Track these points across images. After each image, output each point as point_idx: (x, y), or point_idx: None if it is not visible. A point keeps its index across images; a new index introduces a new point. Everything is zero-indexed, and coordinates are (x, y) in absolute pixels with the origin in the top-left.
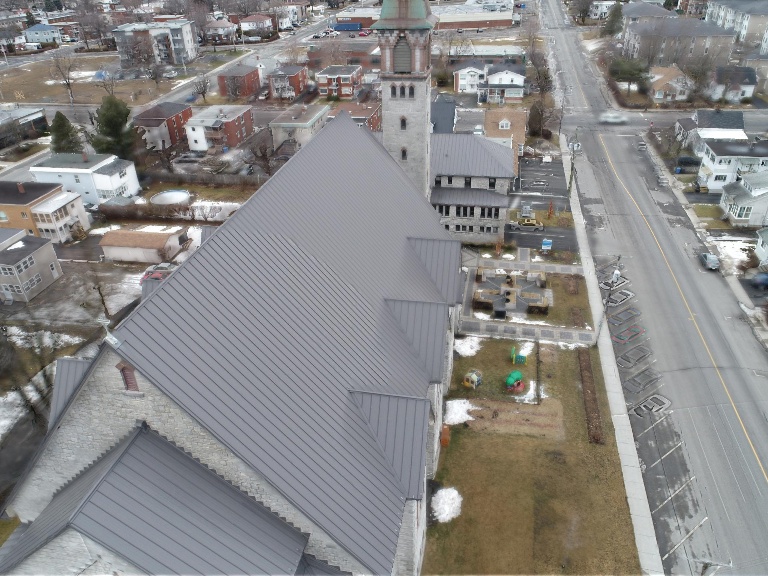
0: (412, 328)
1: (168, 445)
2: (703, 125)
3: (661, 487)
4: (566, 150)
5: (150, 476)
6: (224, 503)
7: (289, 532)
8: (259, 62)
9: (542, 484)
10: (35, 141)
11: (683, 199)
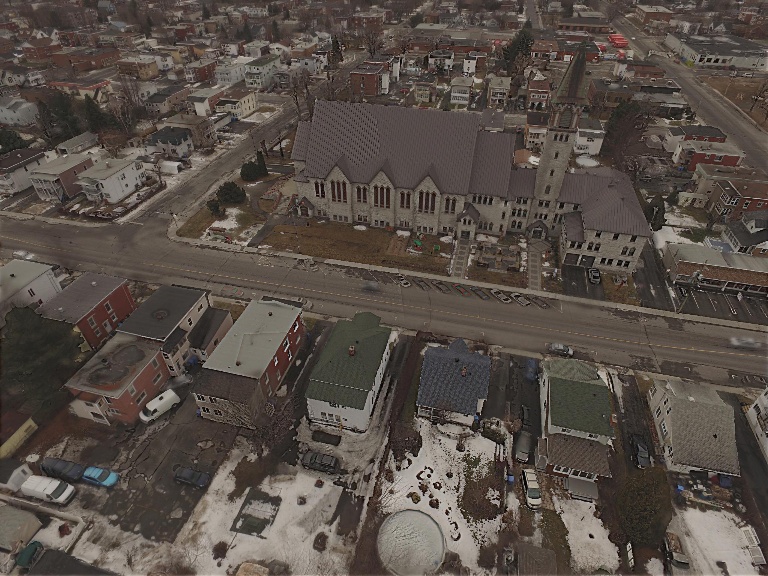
0: None
1: None
2: None
3: None
4: None
5: None
6: None
7: None
8: None
9: None
10: (657, 118)
11: None
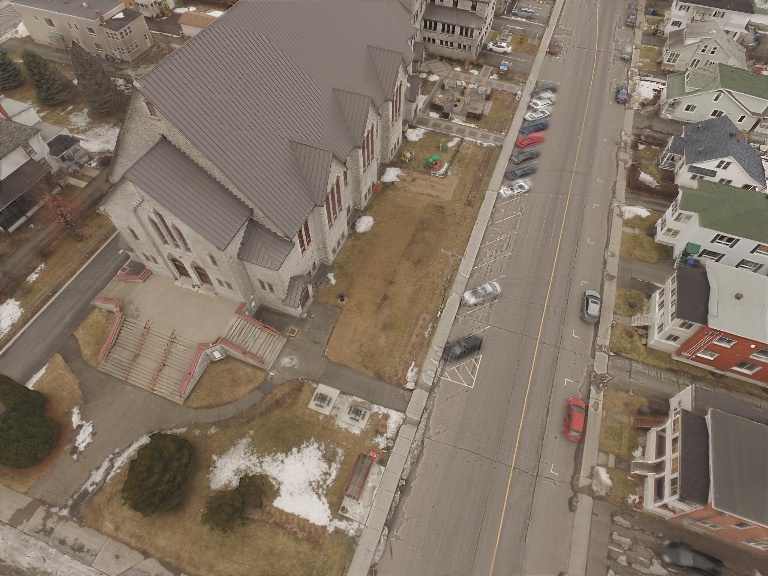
0: (348, 110)
1: (177, 150)
2: None
3: (494, 234)
4: None
5: (166, 163)
6: (207, 185)
7: (242, 206)
8: None
9: (424, 222)
10: None
11: (638, 40)
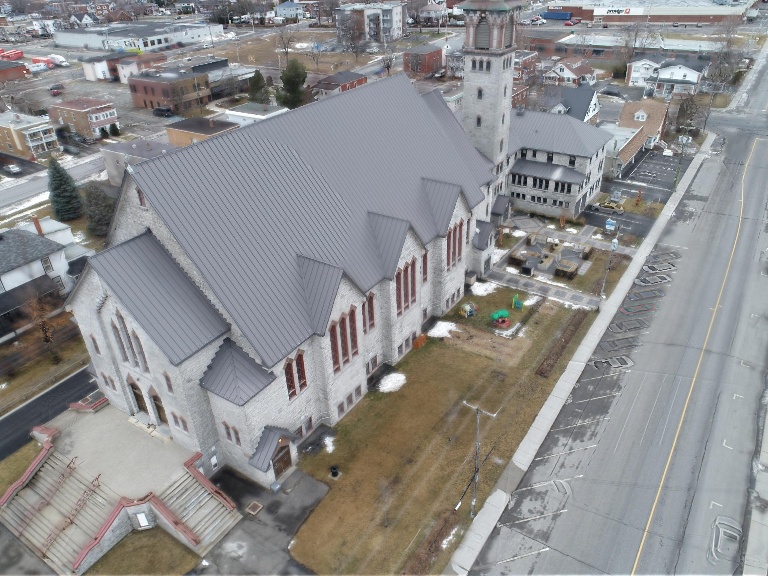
0: (381, 236)
1: (160, 246)
2: None
3: (573, 417)
4: (706, 149)
5: (142, 257)
6: (182, 287)
7: (219, 319)
8: (447, 43)
9: (474, 389)
10: (247, 95)
11: None
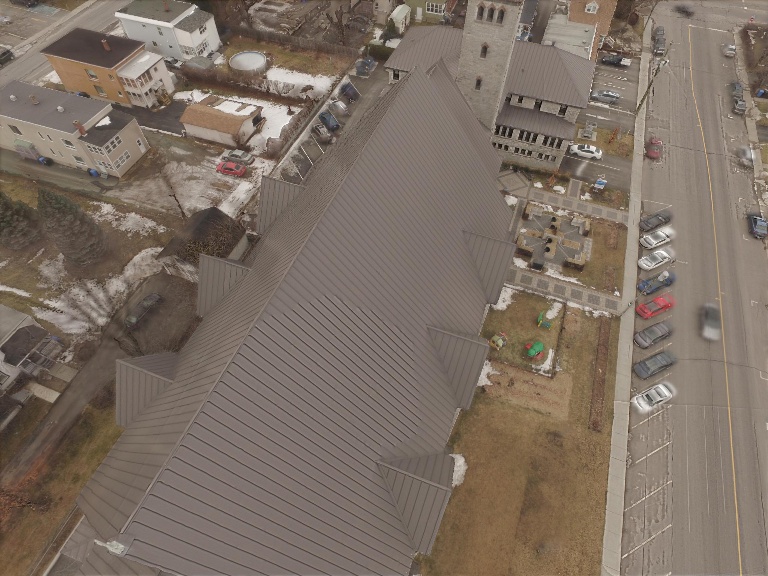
0: (449, 359)
1: None
2: None
3: (639, 486)
4: (648, 44)
5: None
6: None
7: None
8: None
9: (537, 465)
10: None
11: (754, 135)
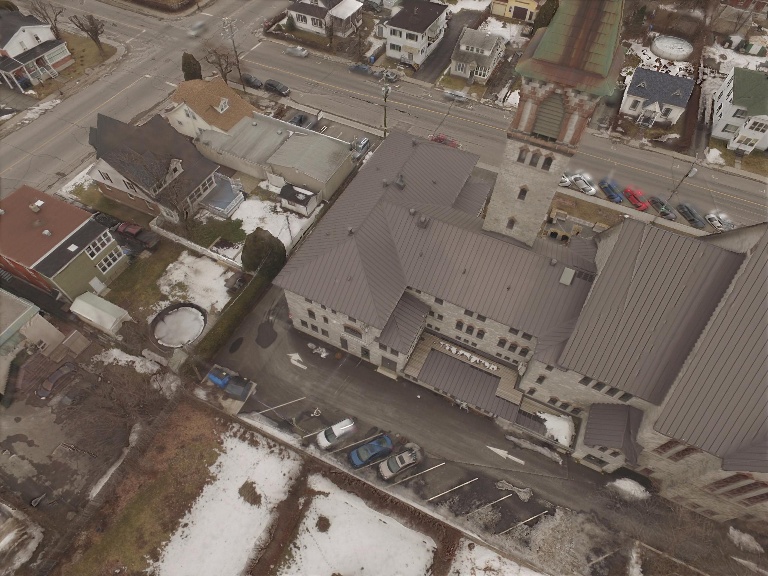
0: None
1: None
2: (330, 6)
3: None
4: (264, 94)
5: None
6: None
7: None
8: None
9: None
10: None
11: (424, 83)
